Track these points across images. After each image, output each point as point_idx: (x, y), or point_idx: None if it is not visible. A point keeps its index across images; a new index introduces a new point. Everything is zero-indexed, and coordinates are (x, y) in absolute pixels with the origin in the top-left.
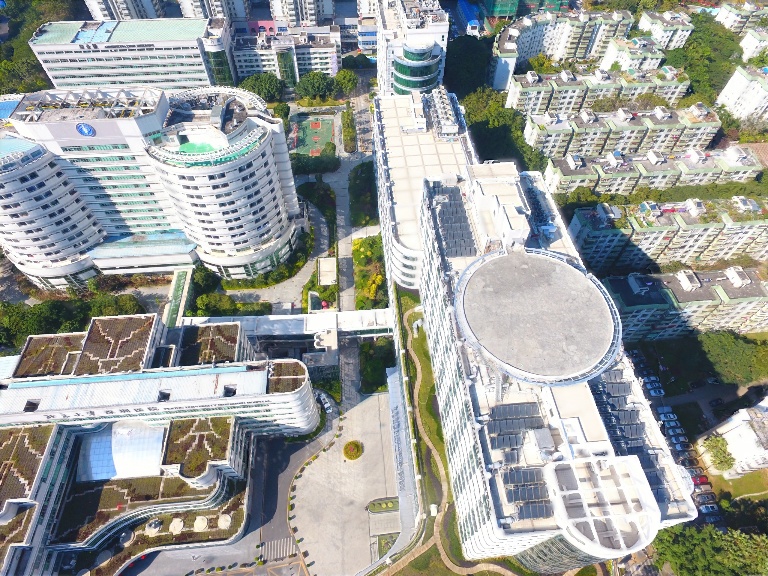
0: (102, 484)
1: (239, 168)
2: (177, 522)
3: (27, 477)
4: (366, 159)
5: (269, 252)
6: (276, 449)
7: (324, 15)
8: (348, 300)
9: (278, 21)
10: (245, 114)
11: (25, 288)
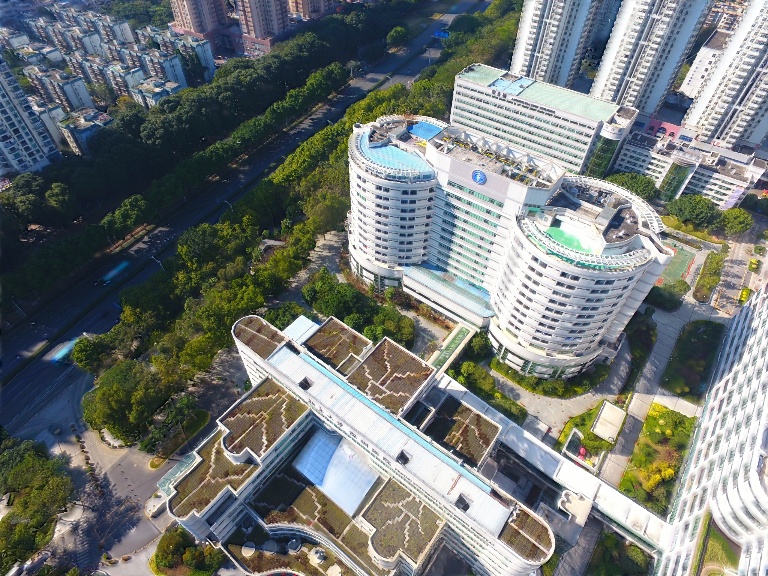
0: (307, 483)
1: (598, 280)
2: (337, 570)
3: (269, 439)
4: (716, 319)
5: (559, 364)
6: (455, 575)
7: (746, 141)
8: (615, 469)
9: (686, 129)
10: (635, 229)
11: (343, 265)
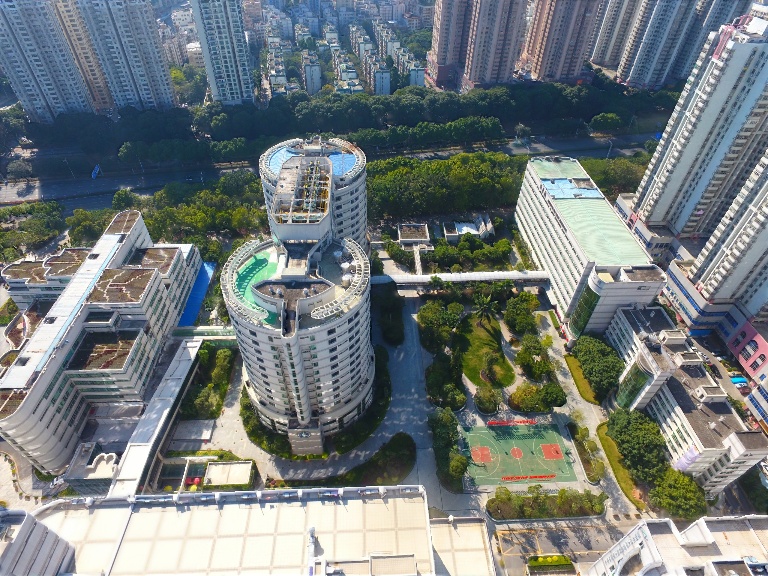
0: None
1: None
2: None
3: (61, 272)
4: None
5: None
6: None
7: None
8: None
9: None
10: (297, 299)
11: None
